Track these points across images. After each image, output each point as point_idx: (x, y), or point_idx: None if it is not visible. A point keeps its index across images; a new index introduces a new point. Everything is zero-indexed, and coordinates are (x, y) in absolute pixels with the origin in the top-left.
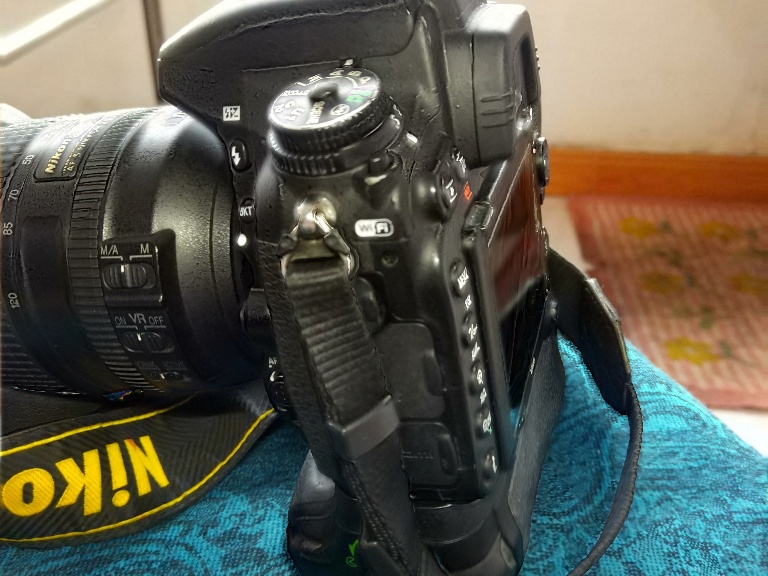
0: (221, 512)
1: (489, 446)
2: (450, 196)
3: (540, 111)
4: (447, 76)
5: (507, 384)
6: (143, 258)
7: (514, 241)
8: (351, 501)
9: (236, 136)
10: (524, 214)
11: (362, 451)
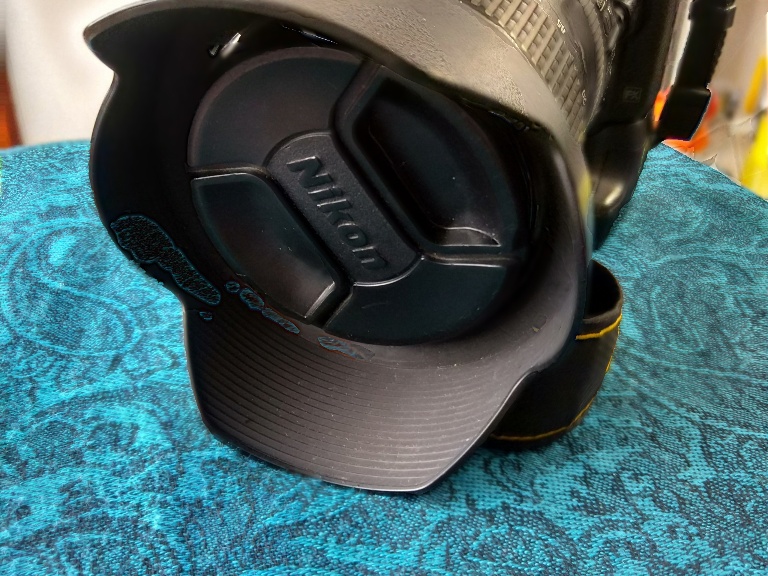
0: None
1: None
2: None
3: None
4: None
5: None
6: None
7: None
8: None
9: None
10: None
11: None
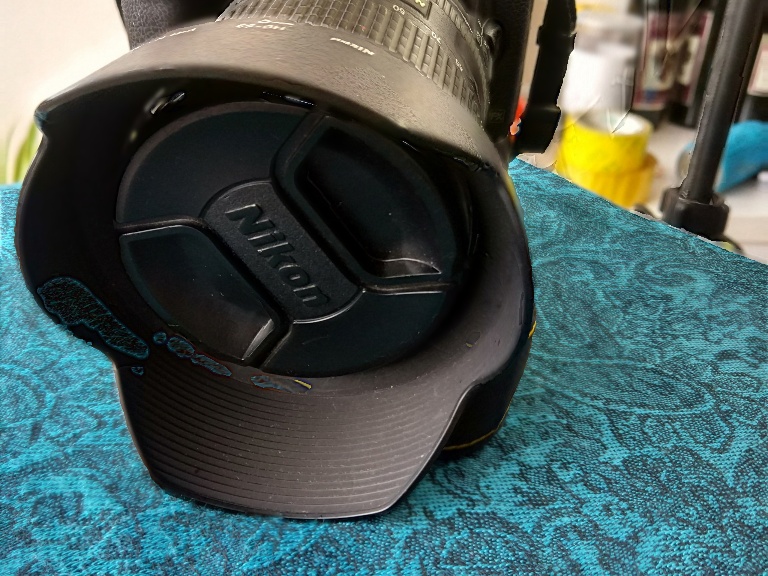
0: None
1: None
2: None
3: None
4: None
5: None
6: None
7: None
8: (506, 139)
9: None
10: None
11: None
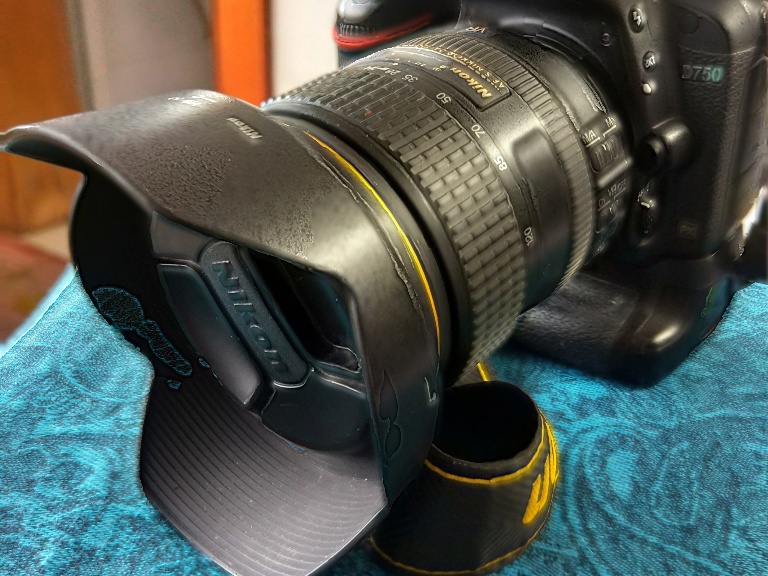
0: (544, 409)
1: None
2: None
3: None
4: None
5: None
6: (611, 131)
7: None
8: None
9: (633, 3)
10: None
11: None
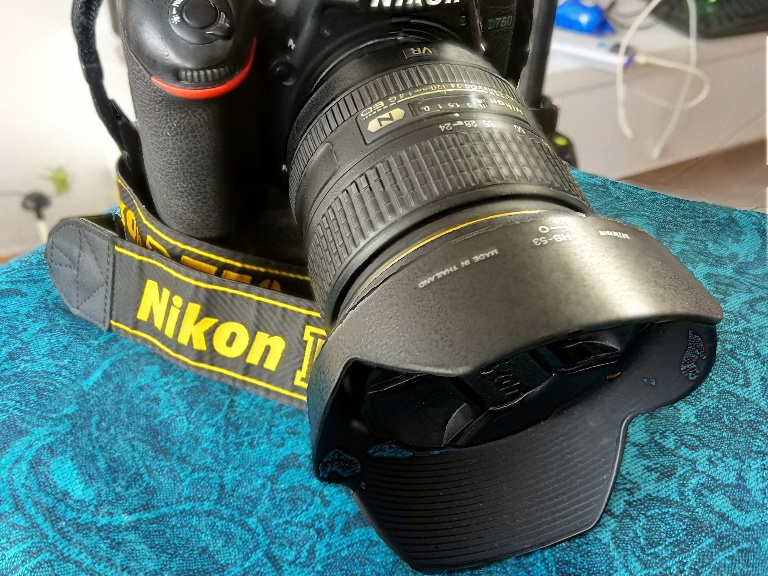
0: None
1: None
2: None
3: None
4: None
5: None
6: None
7: None
8: None
9: None
10: None
11: None
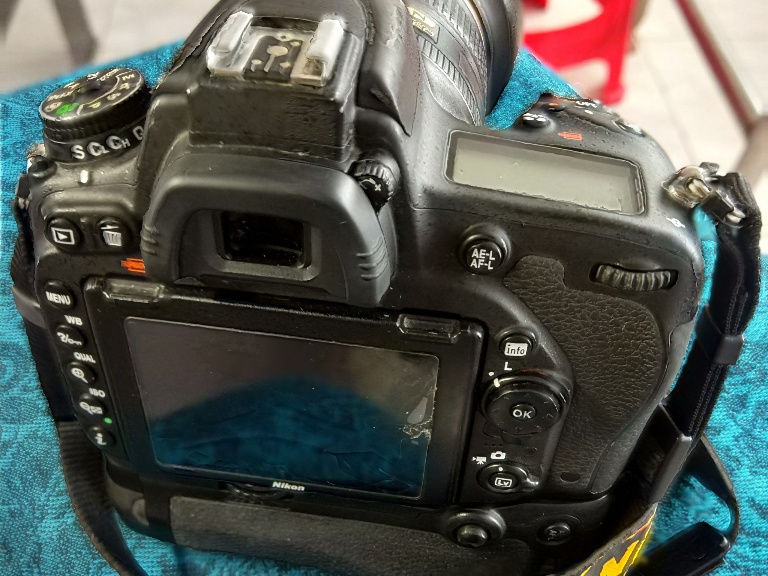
0: None
1: (107, 428)
2: (58, 237)
3: (652, 389)
4: (161, 168)
5: (165, 430)
6: None
7: (264, 375)
8: None
9: None
10: (343, 387)
11: (20, 310)
